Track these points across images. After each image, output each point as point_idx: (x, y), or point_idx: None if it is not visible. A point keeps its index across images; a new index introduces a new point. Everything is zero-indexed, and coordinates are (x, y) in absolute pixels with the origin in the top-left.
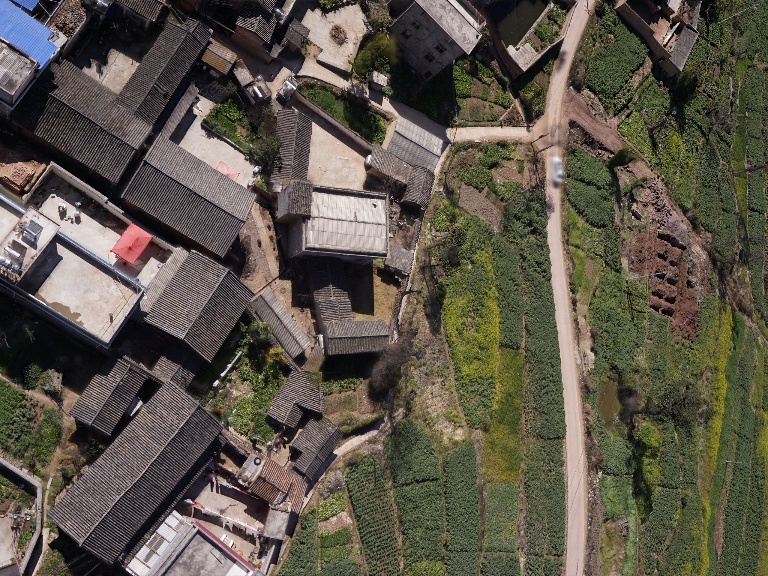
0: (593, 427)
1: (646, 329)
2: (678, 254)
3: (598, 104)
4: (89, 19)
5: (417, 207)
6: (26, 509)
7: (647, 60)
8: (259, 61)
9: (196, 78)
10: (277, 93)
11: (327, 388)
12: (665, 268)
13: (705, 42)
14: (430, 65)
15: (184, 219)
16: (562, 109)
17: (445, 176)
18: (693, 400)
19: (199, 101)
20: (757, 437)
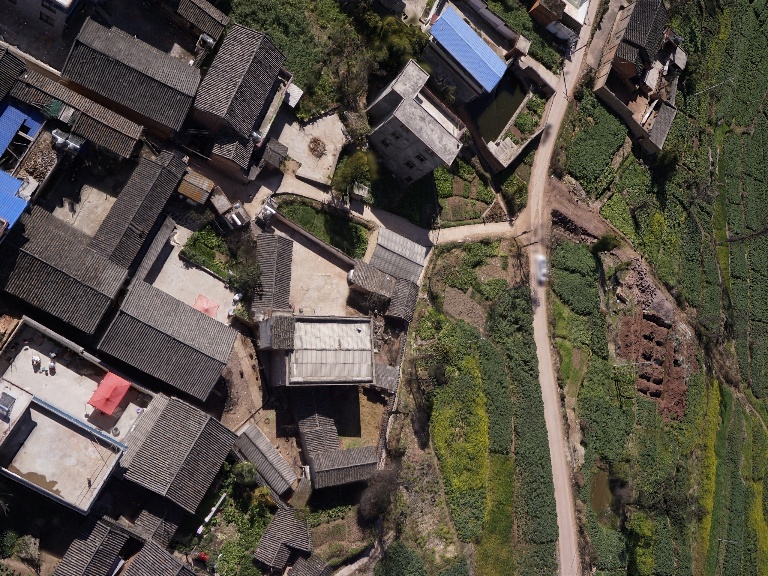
0: (586, 526)
1: (635, 415)
2: (664, 334)
3: (580, 189)
4: (60, 159)
5: (402, 320)
6: None
7: (627, 140)
8: (237, 182)
9: (172, 207)
10: (256, 216)
11: (315, 519)
12: (652, 350)
13: (683, 115)
14: (411, 171)
15: (163, 365)
16: (544, 199)
17: (429, 281)
18: (684, 481)
19: (176, 231)
20: (748, 509)
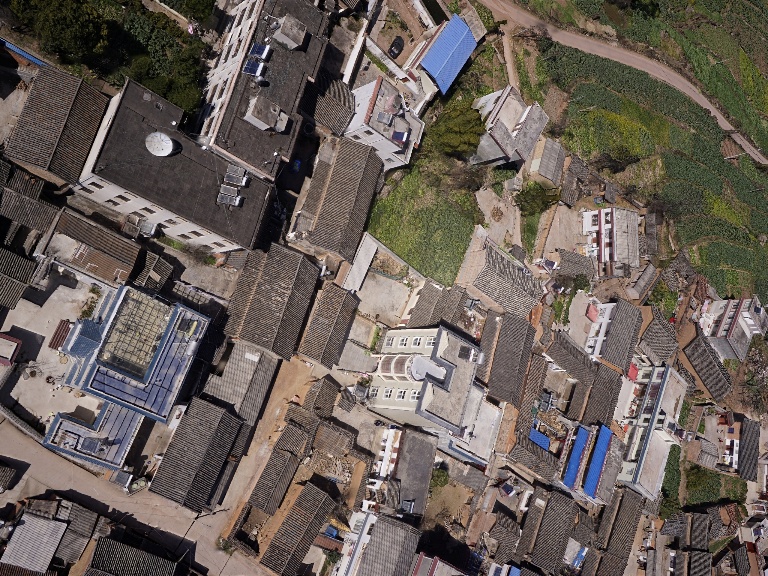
0: None
1: None
2: None
3: None
4: None
5: None
6: (704, 411)
7: None
8: None
9: None
10: None
11: None
12: None
13: None
14: None
15: None
16: None
17: None
18: None
19: None
20: None
